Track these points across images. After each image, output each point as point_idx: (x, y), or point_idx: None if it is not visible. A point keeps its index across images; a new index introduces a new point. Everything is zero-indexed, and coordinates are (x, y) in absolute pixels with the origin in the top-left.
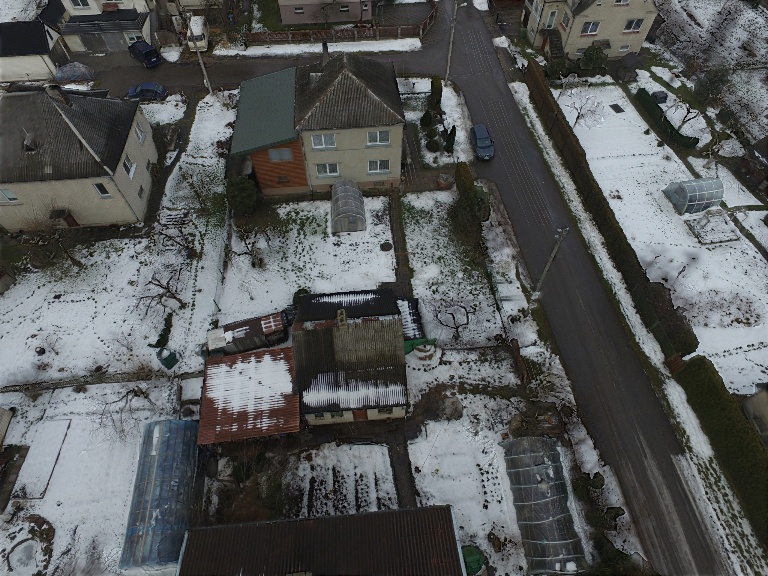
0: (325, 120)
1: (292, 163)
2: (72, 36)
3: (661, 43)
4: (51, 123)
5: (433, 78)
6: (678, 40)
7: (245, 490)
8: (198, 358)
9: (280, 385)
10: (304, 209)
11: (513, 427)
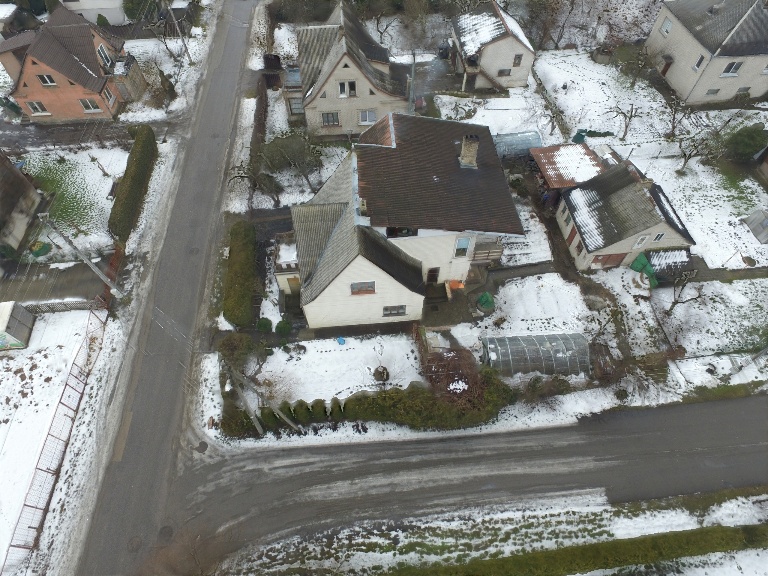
0: None
1: None
2: None
3: None
4: (741, 7)
5: None
6: None
7: None
8: None
9: (580, 176)
10: (760, 197)
11: None
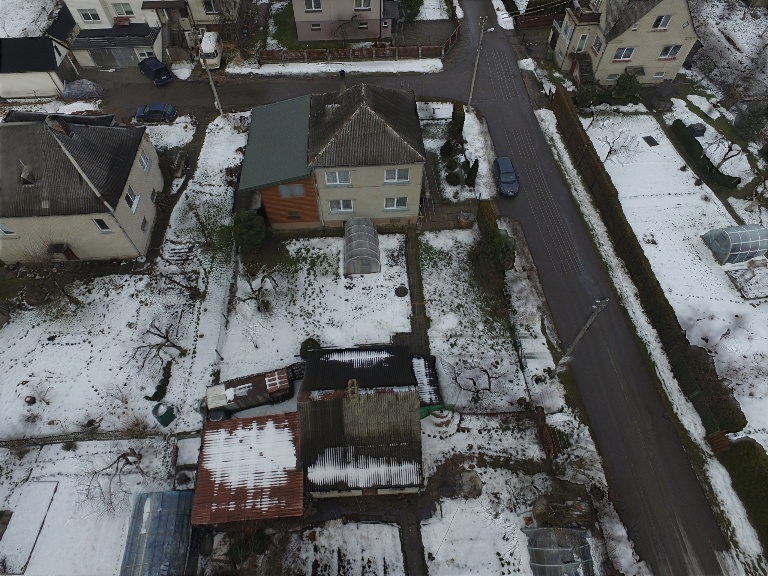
0: (340, 157)
1: (304, 199)
2: (81, 51)
3: (697, 69)
4: (50, 155)
5: (455, 105)
6: (716, 66)
7: (242, 573)
8: (197, 415)
9: (283, 458)
10: (315, 246)
11: (538, 511)
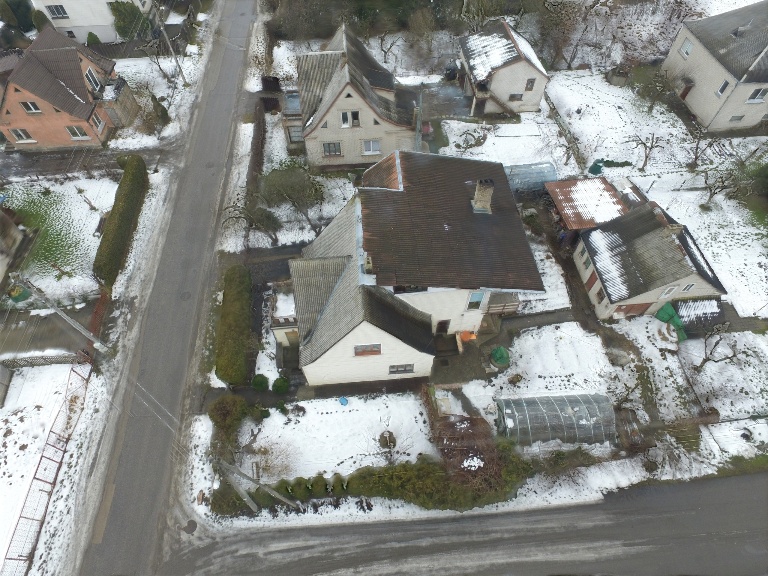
0: None
1: None
2: None
3: None
4: None
5: None
6: None
7: None
8: None
9: (600, 215)
10: None
11: None
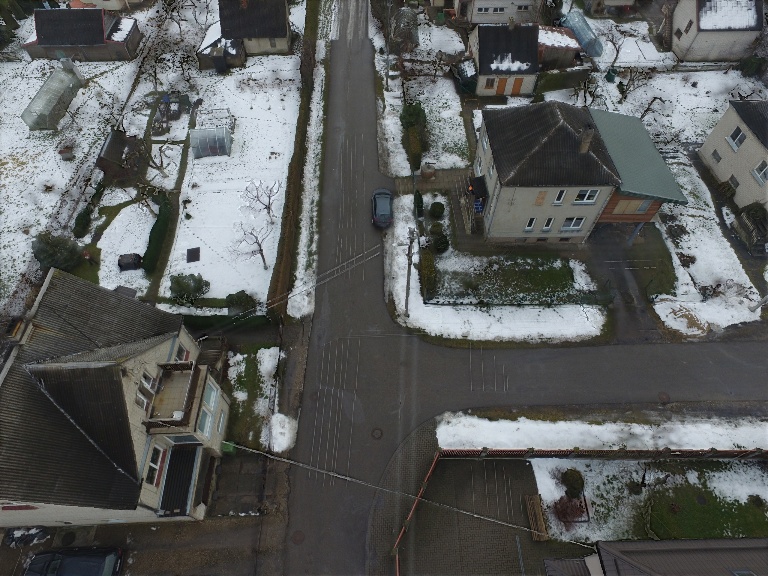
0: None
1: None
2: None
3: None
4: None
5: None
6: None
7: None
8: None
9: None
10: None
11: None
